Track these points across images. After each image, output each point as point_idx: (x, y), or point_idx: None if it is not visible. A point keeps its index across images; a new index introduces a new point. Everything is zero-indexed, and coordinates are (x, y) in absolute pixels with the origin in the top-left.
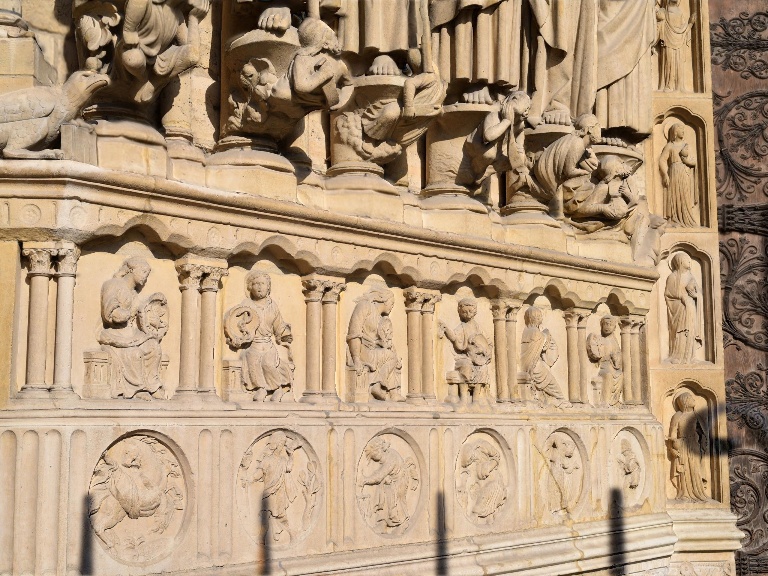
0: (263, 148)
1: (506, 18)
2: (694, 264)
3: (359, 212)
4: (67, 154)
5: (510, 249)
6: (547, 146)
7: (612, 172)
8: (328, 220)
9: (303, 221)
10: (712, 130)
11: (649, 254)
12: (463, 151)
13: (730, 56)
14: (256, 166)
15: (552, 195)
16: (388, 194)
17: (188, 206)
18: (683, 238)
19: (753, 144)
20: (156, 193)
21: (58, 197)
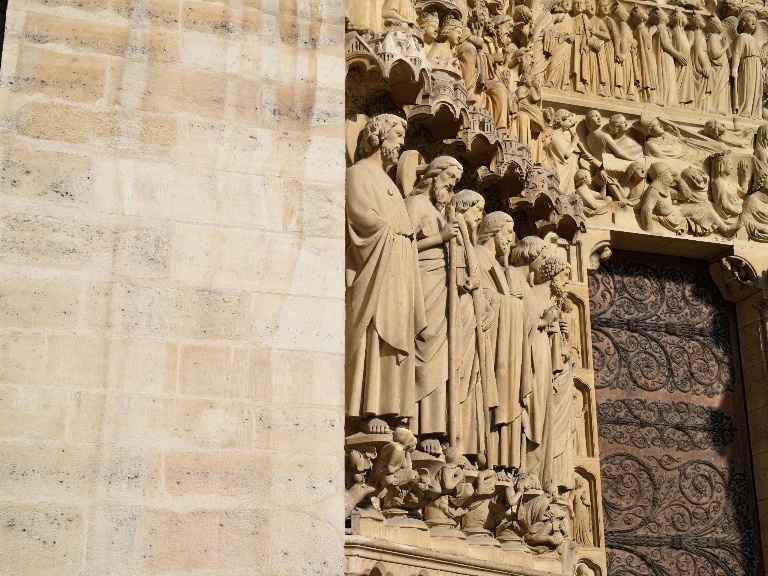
0: (414, 516)
1: (516, 428)
2: (590, 572)
3: (450, 551)
4: (355, 531)
5: (514, 570)
6: (527, 502)
7: (555, 515)
8: (445, 559)
9: (435, 560)
10: (600, 482)
11: (571, 567)
12: (489, 508)
13: (601, 428)
14: (414, 528)
15: (527, 532)
16: (463, 539)
17: (394, 556)
18: (585, 554)
19: (617, 488)
20: (385, 550)
21: (350, 555)
